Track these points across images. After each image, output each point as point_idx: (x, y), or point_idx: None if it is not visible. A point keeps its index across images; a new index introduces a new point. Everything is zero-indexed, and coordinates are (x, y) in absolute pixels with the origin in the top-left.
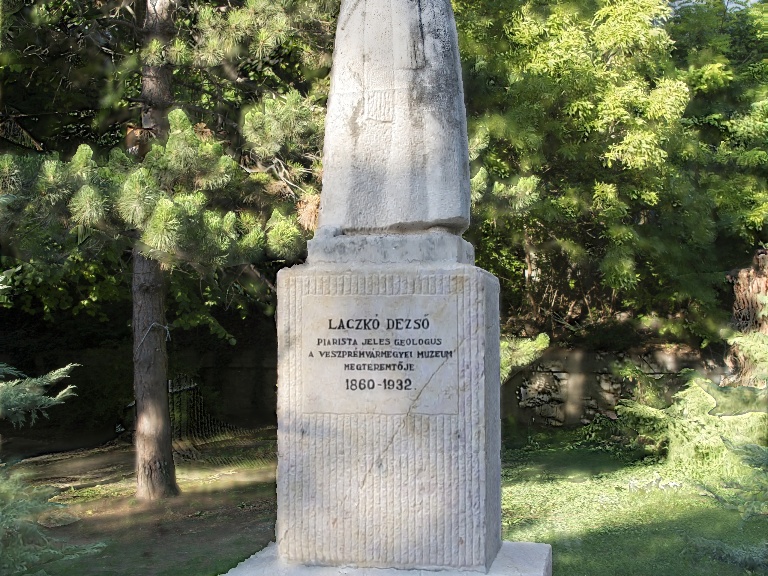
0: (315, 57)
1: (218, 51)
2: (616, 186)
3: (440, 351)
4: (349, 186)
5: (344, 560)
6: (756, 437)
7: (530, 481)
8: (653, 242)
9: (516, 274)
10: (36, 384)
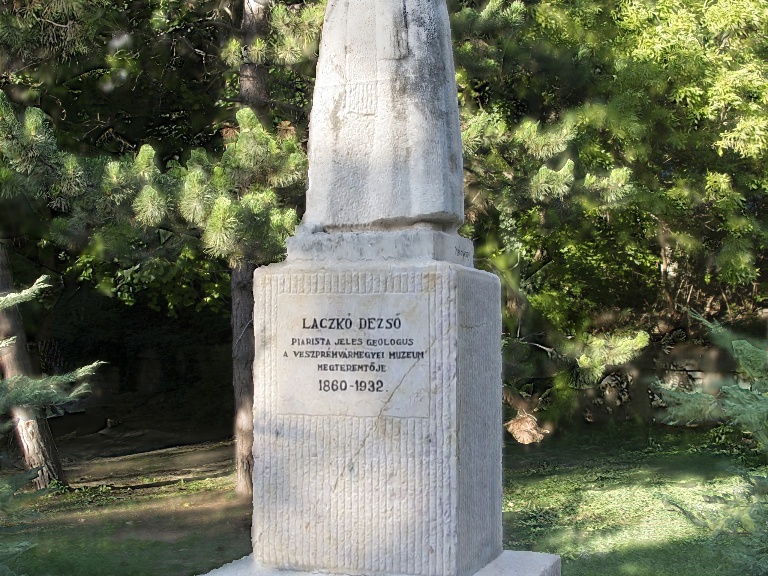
0: None
1: (295, 49)
2: (733, 176)
3: (411, 352)
4: (330, 182)
5: (316, 566)
6: None
7: (636, 485)
8: None
9: (651, 269)
10: (62, 381)
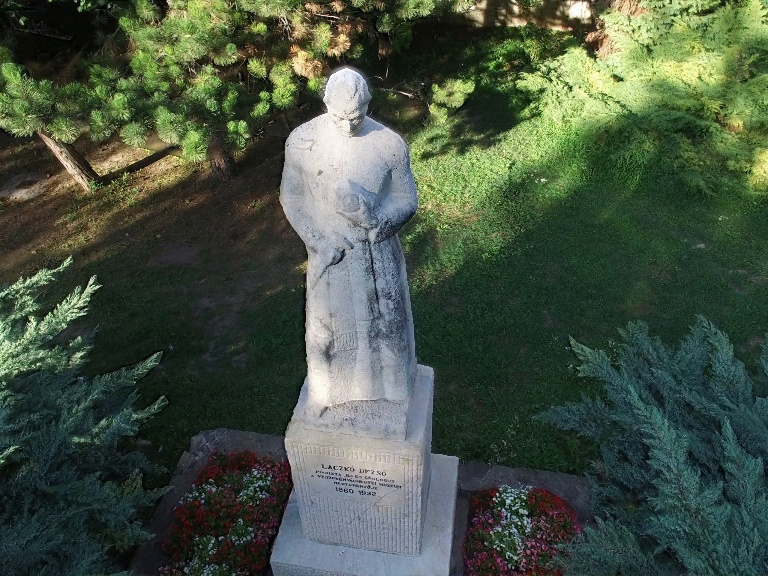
0: None
1: None
2: None
3: (394, 485)
4: (328, 387)
5: (342, 543)
6: None
7: (457, 148)
8: None
9: None
10: None
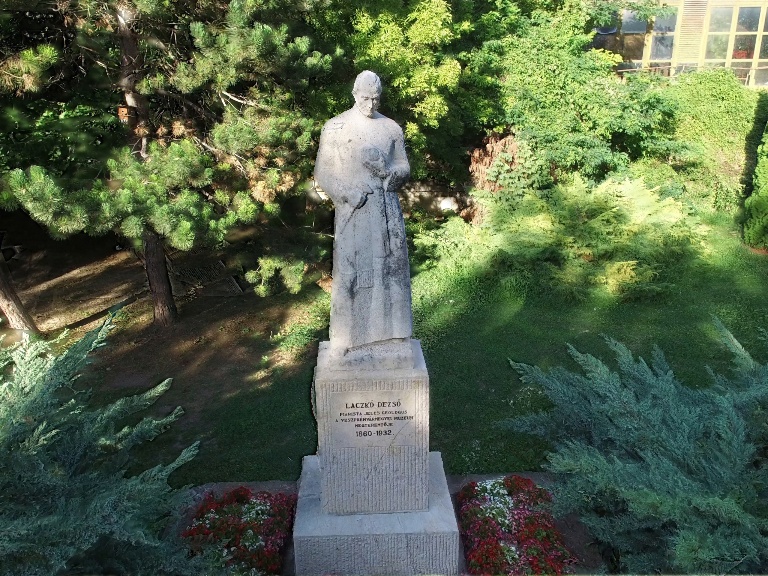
0: None
1: (189, 85)
2: None
3: (407, 416)
4: (351, 326)
5: (358, 511)
6: None
7: None
8: (431, 138)
9: None
10: (152, 396)
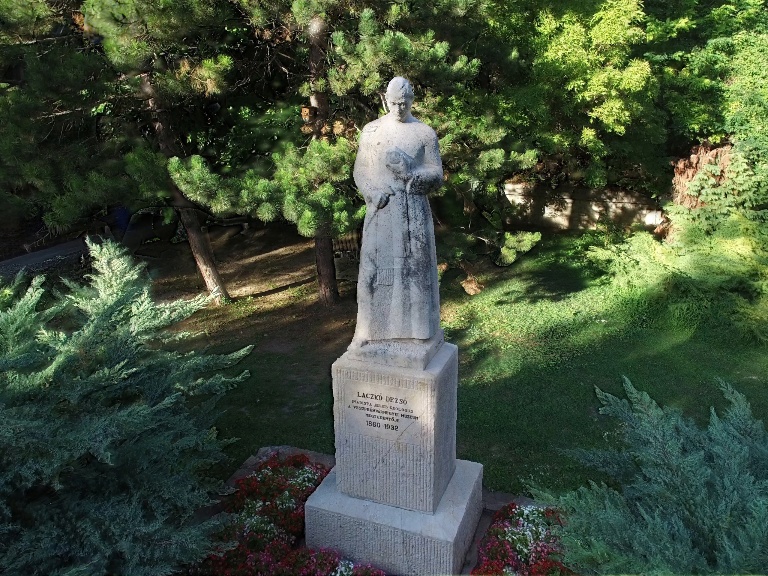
0: (405, 76)
1: (343, 88)
2: None
3: (412, 416)
4: (369, 319)
5: (367, 497)
6: (661, 288)
7: (530, 299)
8: (624, 146)
9: None
10: (234, 358)
